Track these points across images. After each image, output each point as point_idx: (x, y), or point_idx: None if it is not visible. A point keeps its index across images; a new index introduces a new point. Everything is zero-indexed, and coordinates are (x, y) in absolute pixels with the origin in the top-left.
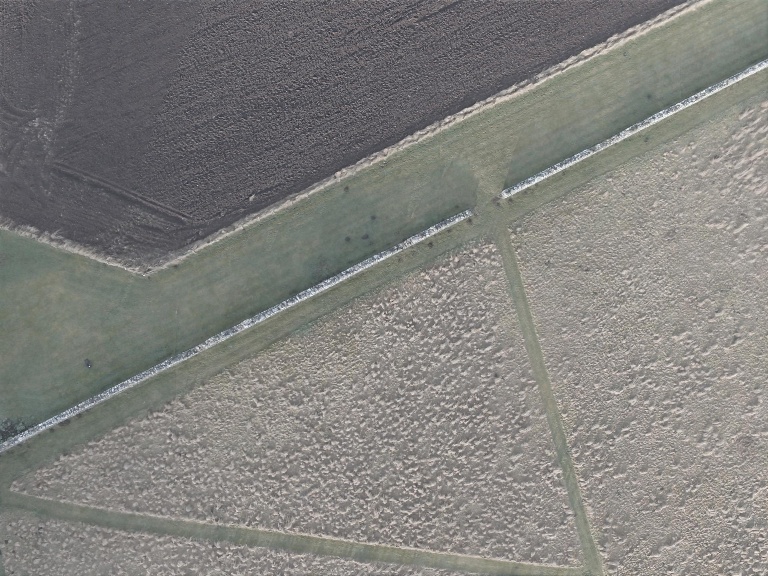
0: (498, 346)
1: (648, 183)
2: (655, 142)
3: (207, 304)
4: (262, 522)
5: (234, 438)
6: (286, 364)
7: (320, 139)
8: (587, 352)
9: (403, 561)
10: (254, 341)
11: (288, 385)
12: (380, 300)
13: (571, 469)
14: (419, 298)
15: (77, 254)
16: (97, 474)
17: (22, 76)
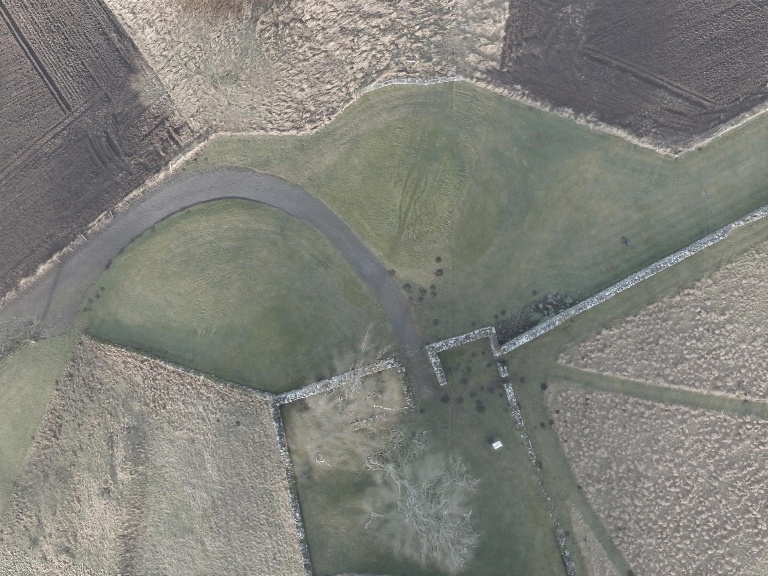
0: None
1: None
2: None
3: (732, 185)
4: None
5: (758, 315)
6: None
7: None
8: None
9: None
10: None
11: None
12: None
13: None
14: None
15: (613, 135)
16: (634, 348)
17: None
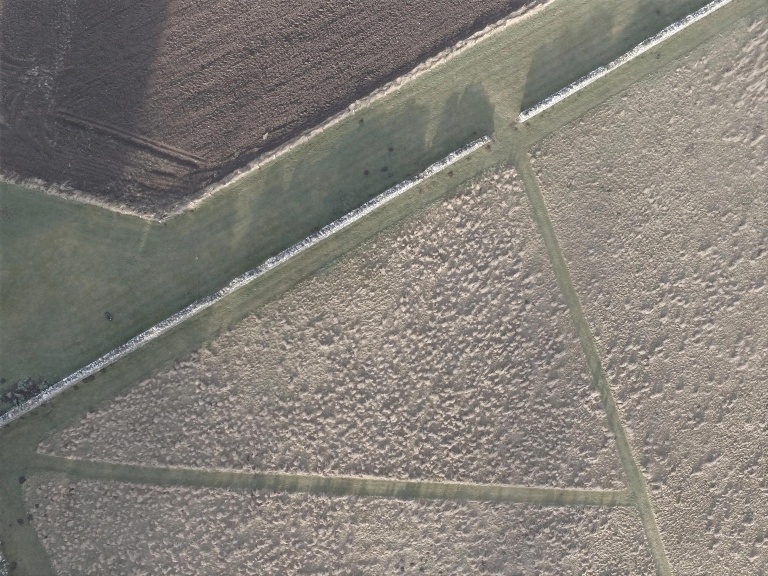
0: (526, 272)
1: (663, 100)
2: (667, 59)
3: (227, 247)
4: (300, 467)
5: (265, 383)
6: (313, 303)
7: (331, 72)
8: (615, 273)
9: (447, 496)
10: (279, 282)
11: (317, 325)
12: (404, 233)
13: (608, 392)
14: (443, 228)
15: (89, 204)
16: (126, 430)
17: (17, 24)
